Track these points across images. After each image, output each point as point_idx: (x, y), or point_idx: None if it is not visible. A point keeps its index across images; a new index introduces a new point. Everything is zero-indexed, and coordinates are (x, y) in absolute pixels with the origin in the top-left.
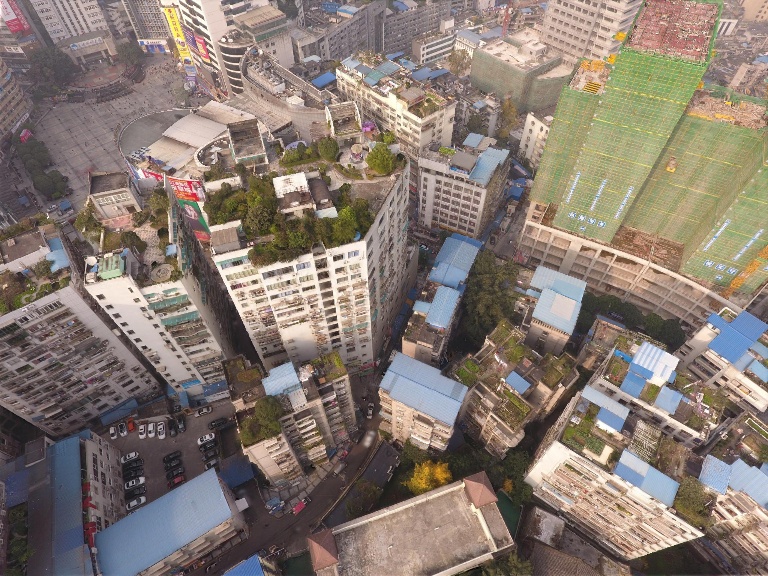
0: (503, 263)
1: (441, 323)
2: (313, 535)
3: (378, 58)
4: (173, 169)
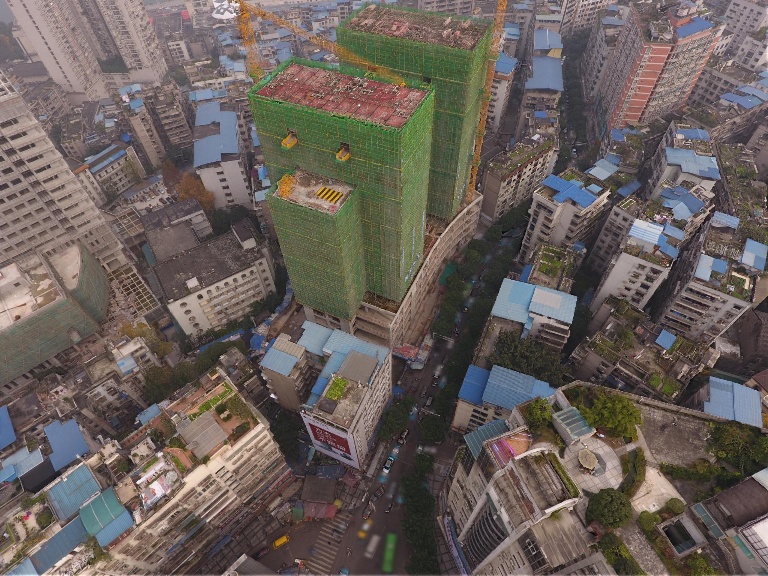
0: (486, 349)
1: None
2: None
3: (26, 516)
4: None
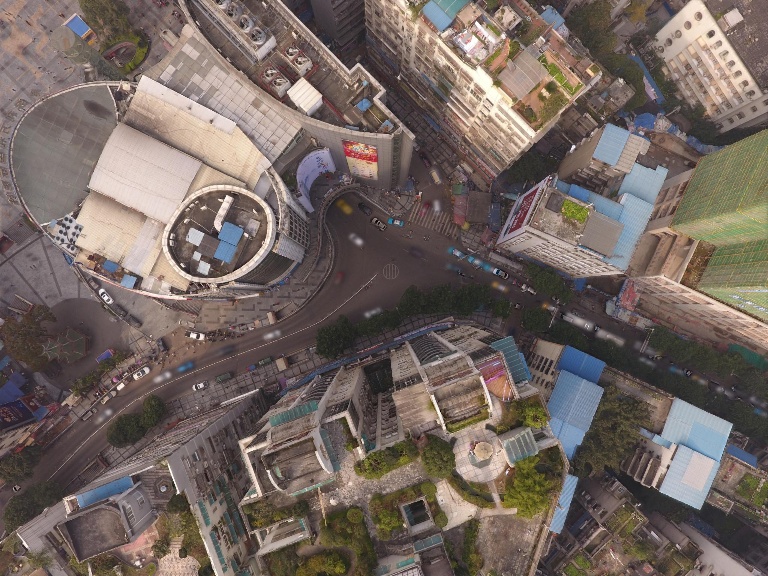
0: (627, 385)
1: (554, 528)
2: None
3: None
4: (138, 277)
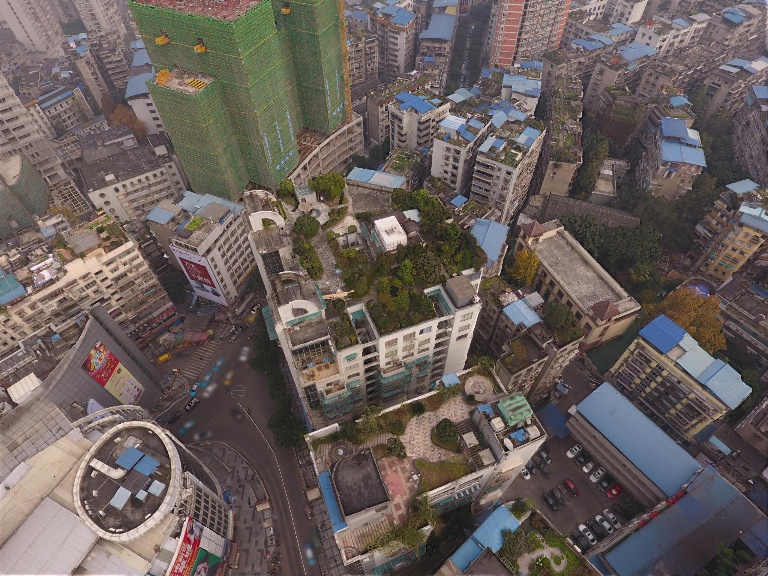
0: None
1: None
2: (600, 316)
3: None
4: None
